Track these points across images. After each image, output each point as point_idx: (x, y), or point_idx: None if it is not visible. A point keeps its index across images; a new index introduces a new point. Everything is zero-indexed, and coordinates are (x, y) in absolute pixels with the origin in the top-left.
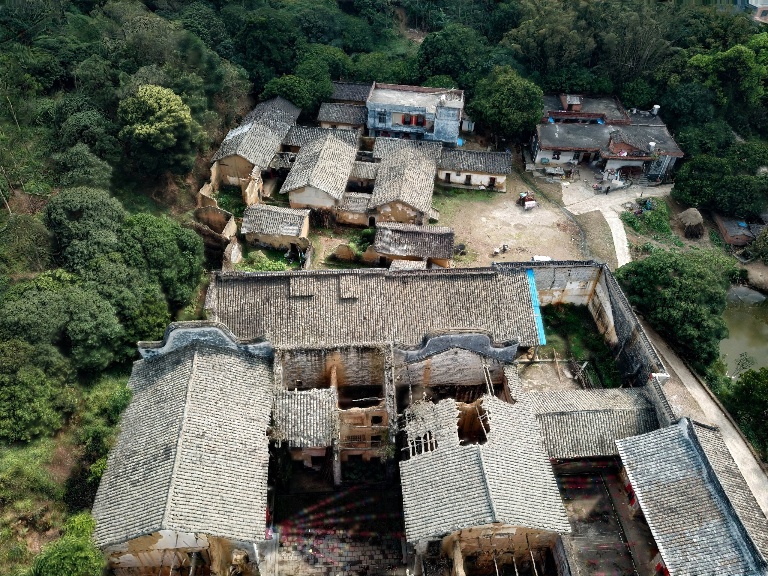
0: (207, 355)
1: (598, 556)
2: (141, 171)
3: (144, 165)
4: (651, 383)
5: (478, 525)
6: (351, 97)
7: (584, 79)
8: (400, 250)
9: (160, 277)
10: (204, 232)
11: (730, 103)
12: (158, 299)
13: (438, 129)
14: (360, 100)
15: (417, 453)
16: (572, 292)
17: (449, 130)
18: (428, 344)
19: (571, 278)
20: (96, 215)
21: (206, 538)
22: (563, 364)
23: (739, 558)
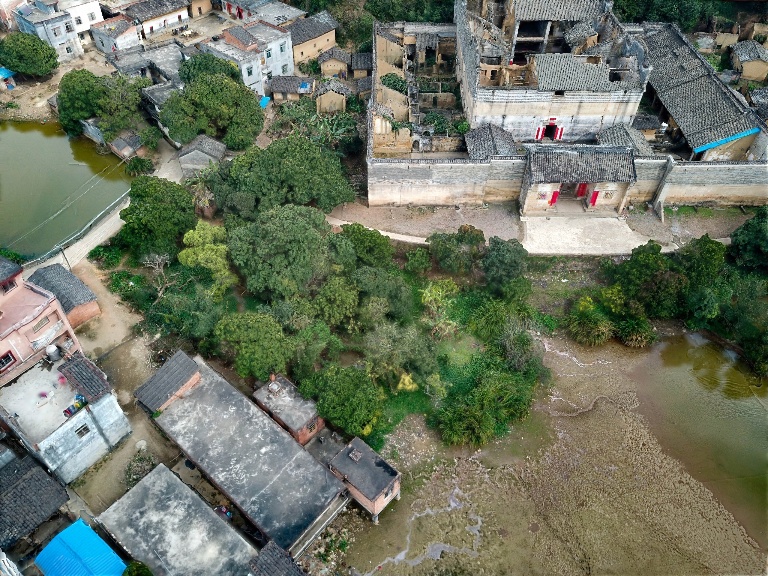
0: None
1: None
2: None
3: None
4: None
5: None
6: None
7: None
8: (757, 99)
9: None
10: None
11: None
12: (637, 3)
13: None
14: None
15: None
16: None
17: None
18: None
19: None
20: None
21: None
22: None
23: None
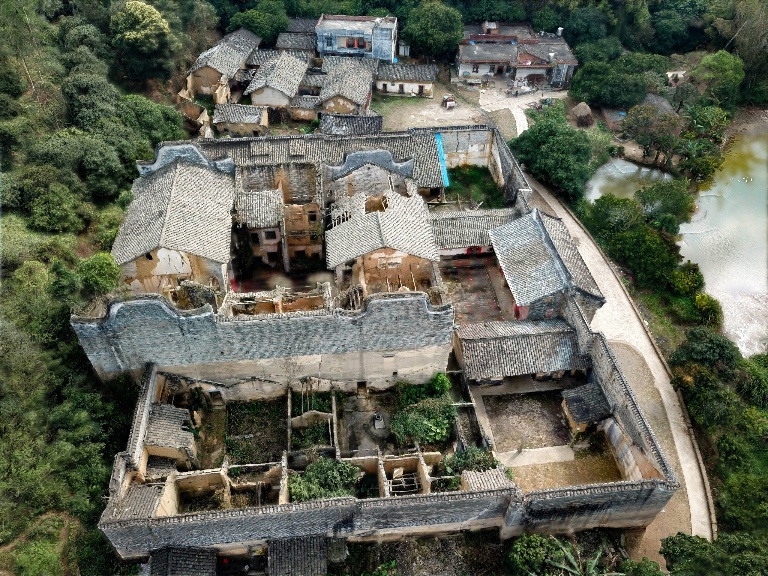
0: (186, 166)
1: (476, 310)
2: (130, 74)
3: (133, 68)
4: (518, 196)
5: (374, 254)
6: (304, 29)
7: (500, 9)
8: (340, 130)
9: (150, 136)
10: (183, 118)
11: (623, 25)
12: (149, 150)
13: (375, 48)
14: (312, 31)
15: (337, 225)
16: (474, 155)
17: (384, 49)
18: (347, 160)
19: (471, 141)
20: (99, 92)
21: (189, 263)
22: (465, 204)
23: (557, 279)
